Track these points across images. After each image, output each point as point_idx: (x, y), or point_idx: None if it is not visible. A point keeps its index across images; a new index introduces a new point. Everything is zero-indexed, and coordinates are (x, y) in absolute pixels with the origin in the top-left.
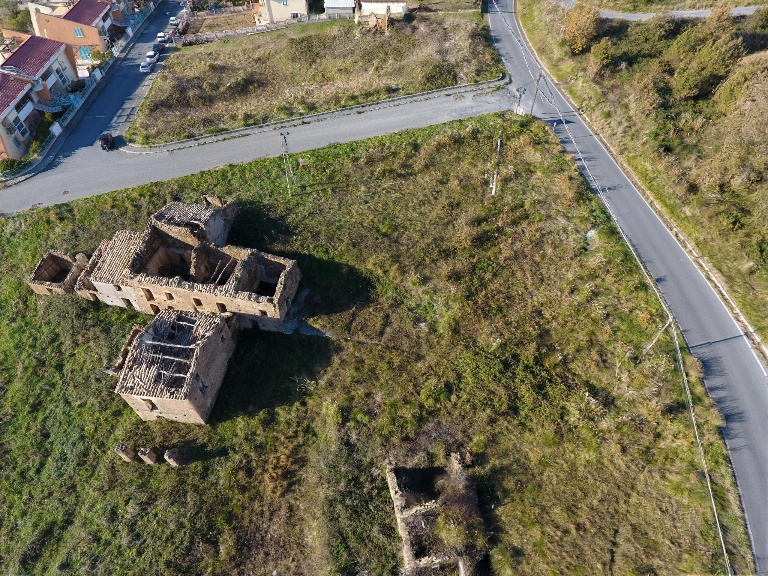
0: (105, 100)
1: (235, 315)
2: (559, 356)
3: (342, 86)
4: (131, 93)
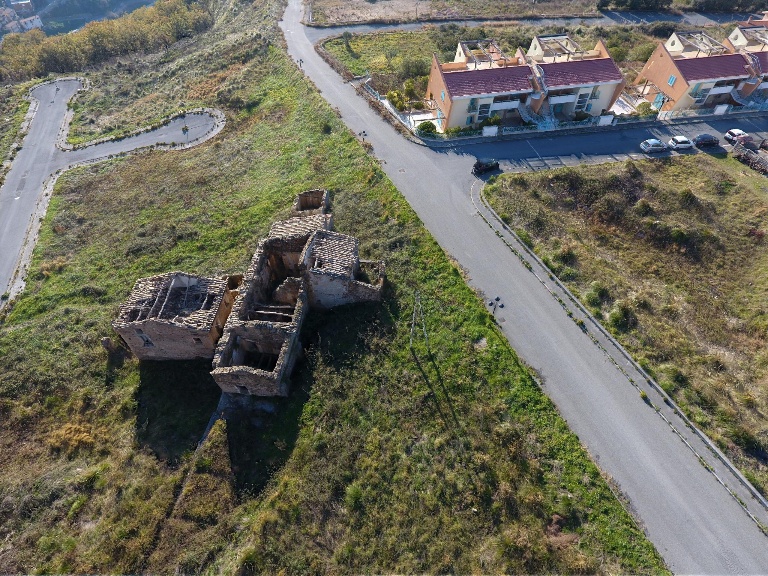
0: (566, 142)
1: None
2: None
3: (710, 355)
4: (592, 153)
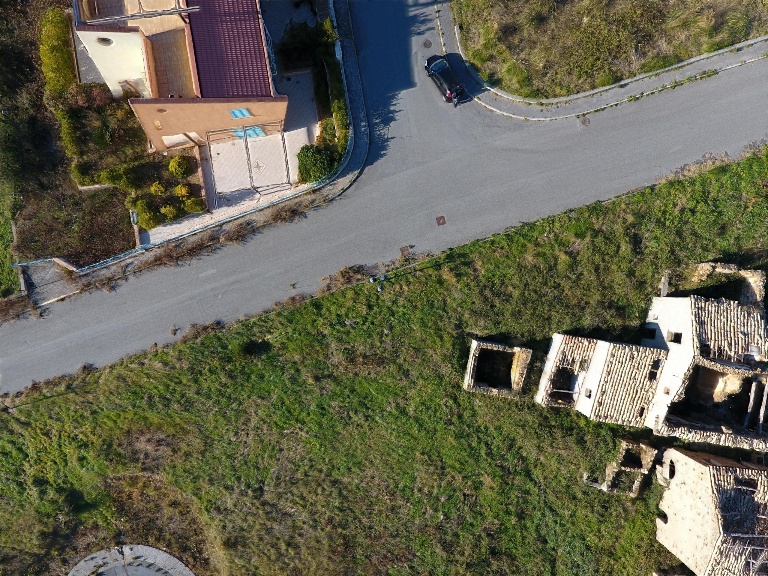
0: None
1: None
2: None
3: None
4: None
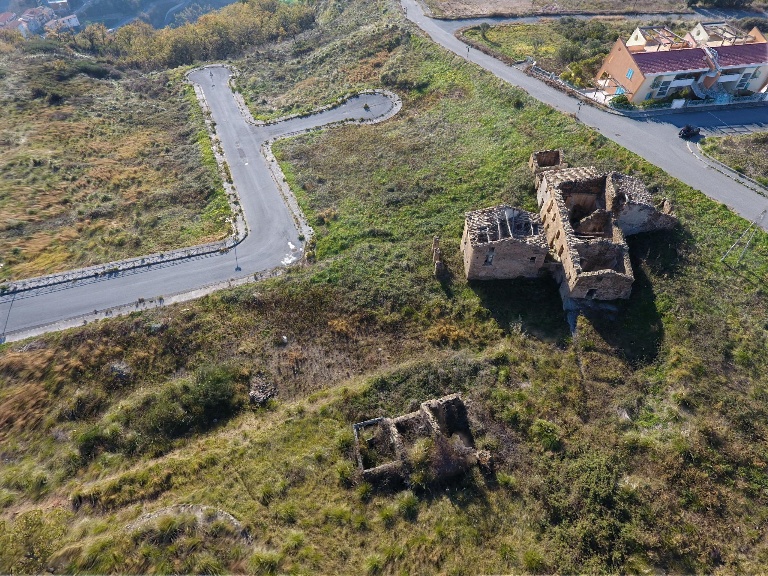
0: (743, 113)
1: (560, 263)
2: (648, 570)
3: None
4: None
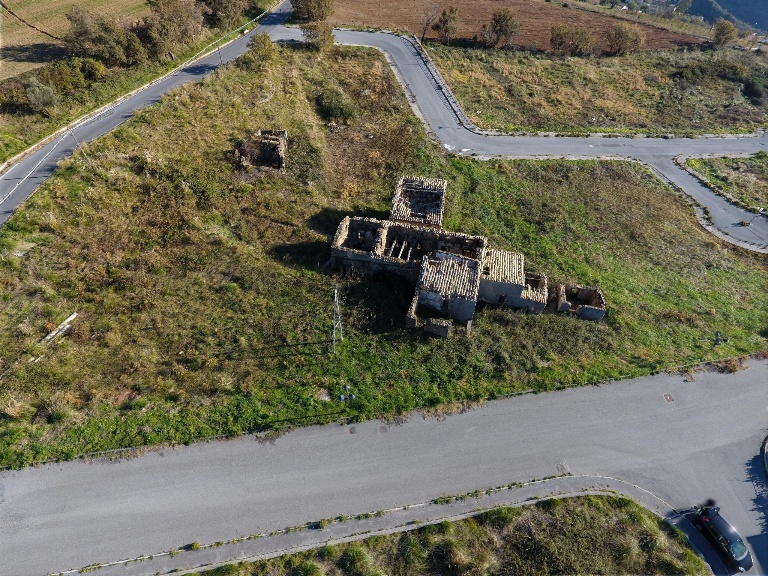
0: None
1: None
2: None
3: None
4: None
